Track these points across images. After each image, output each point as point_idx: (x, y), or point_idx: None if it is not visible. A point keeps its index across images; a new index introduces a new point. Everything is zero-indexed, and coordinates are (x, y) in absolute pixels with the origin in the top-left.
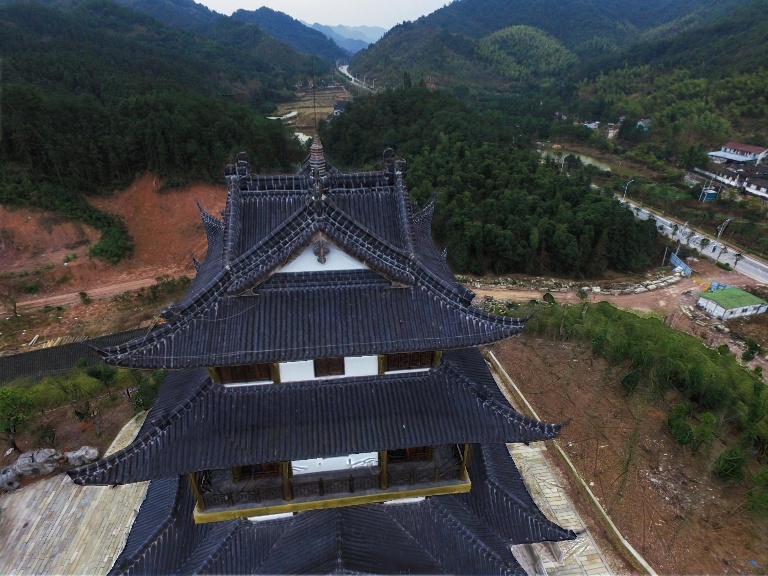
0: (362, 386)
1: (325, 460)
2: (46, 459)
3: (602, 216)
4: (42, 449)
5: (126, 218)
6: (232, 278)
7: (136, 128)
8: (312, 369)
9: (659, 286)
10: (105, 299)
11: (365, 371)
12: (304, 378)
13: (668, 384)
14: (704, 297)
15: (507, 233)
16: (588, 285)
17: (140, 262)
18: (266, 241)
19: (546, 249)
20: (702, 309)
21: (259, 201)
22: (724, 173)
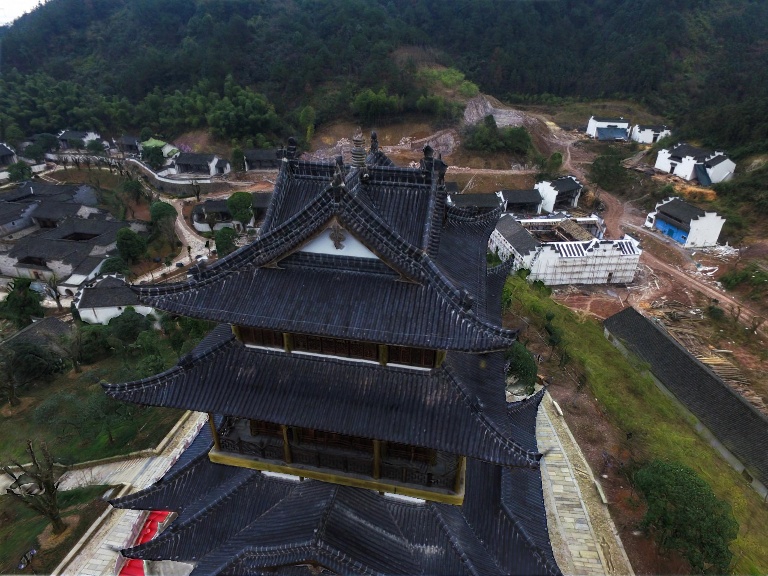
0: None
1: None
2: None
3: None
4: None
5: None
6: None
7: None
8: None
9: None
10: None
11: None
12: None
13: None
14: None
15: None
16: None
17: None
18: None
19: None
20: None
21: None
22: None
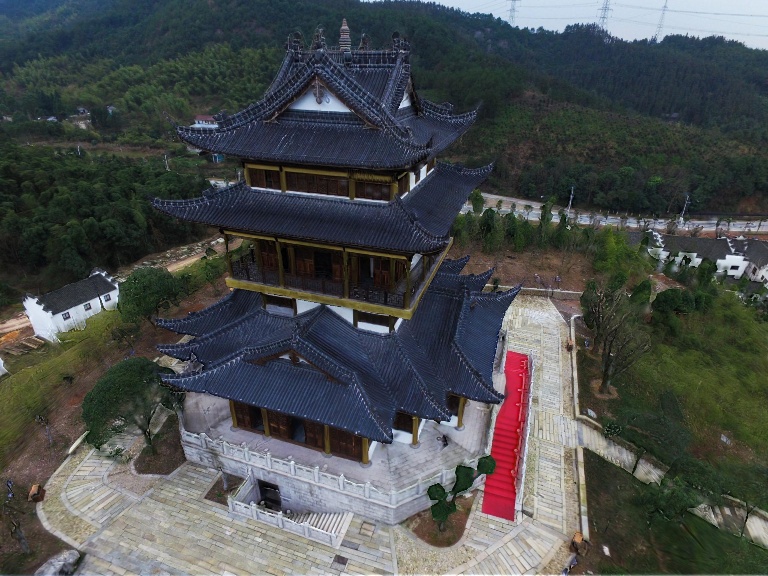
0: None
1: None
2: None
3: (178, 183)
4: None
5: None
6: None
7: None
8: None
9: None
10: None
11: None
12: (413, 186)
13: None
14: None
15: (111, 221)
16: (212, 240)
17: None
18: None
19: (154, 226)
20: None
21: None
22: None
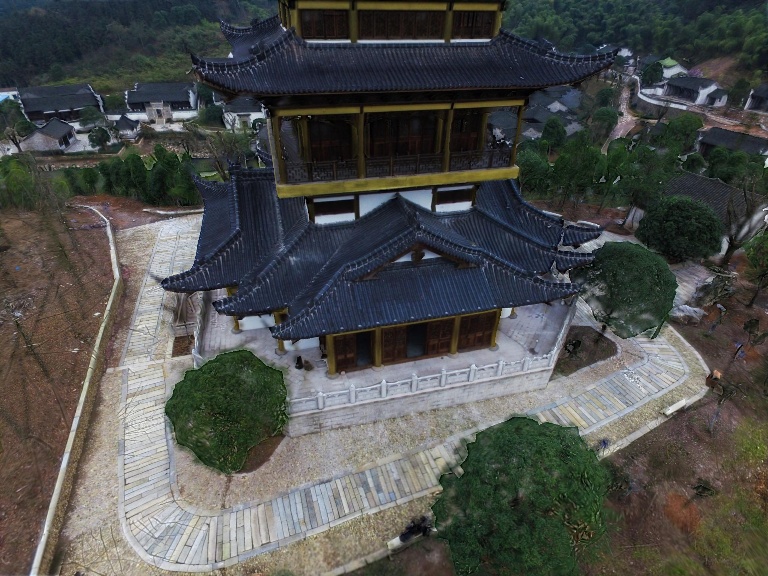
0: None
1: None
2: None
3: None
4: None
5: None
6: None
7: None
8: None
9: None
10: None
11: None
12: None
13: None
14: None
15: None
16: None
17: None
18: None
19: None
20: None
21: None
22: None
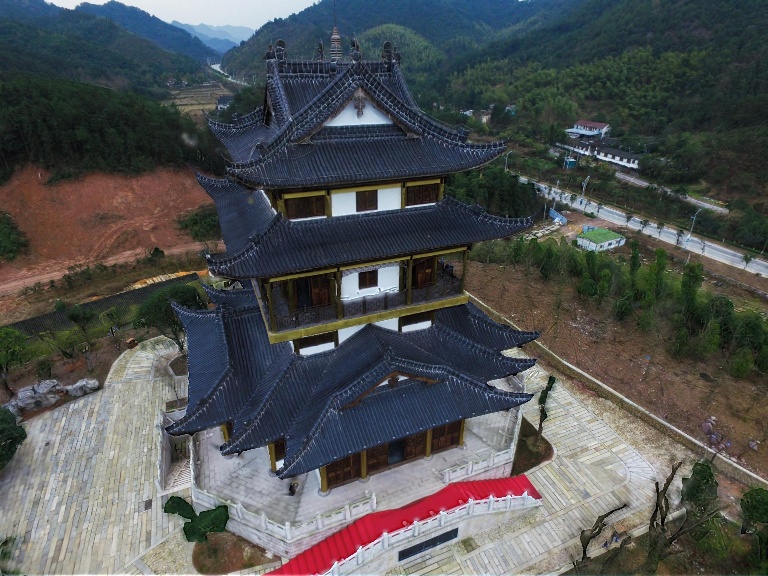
0: (391, 217)
1: (361, 290)
2: (49, 389)
3: (492, 180)
4: (43, 381)
5: (12, 214)
6: (293, 129)
7: (10, 115)
8: (355, 204)
9: (545, 234)
10: (9, 295)
11: (392, 206)
12: (349, 213)
13: (571, 276)
14: (580, 237)
15: None
16: None
17: (40, 257)
18: (319, 98)
19: None
20: (579, 247)
21: (292, 82)
22: (579, 145)
